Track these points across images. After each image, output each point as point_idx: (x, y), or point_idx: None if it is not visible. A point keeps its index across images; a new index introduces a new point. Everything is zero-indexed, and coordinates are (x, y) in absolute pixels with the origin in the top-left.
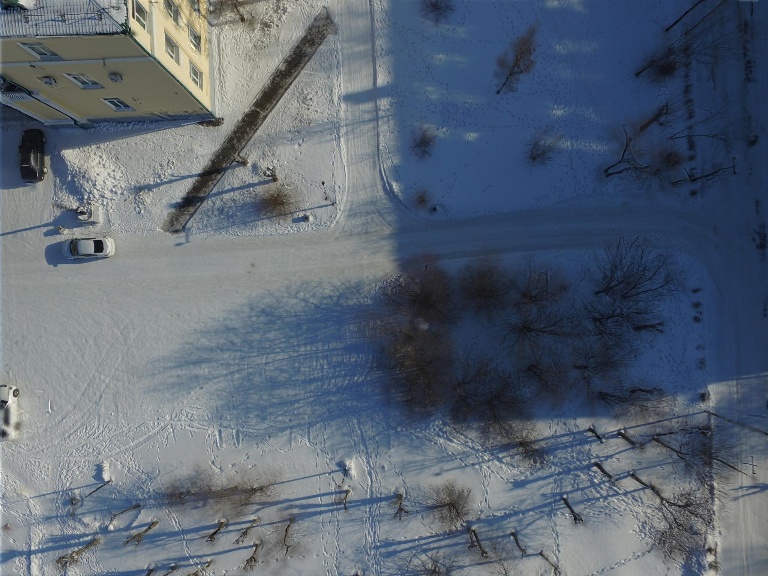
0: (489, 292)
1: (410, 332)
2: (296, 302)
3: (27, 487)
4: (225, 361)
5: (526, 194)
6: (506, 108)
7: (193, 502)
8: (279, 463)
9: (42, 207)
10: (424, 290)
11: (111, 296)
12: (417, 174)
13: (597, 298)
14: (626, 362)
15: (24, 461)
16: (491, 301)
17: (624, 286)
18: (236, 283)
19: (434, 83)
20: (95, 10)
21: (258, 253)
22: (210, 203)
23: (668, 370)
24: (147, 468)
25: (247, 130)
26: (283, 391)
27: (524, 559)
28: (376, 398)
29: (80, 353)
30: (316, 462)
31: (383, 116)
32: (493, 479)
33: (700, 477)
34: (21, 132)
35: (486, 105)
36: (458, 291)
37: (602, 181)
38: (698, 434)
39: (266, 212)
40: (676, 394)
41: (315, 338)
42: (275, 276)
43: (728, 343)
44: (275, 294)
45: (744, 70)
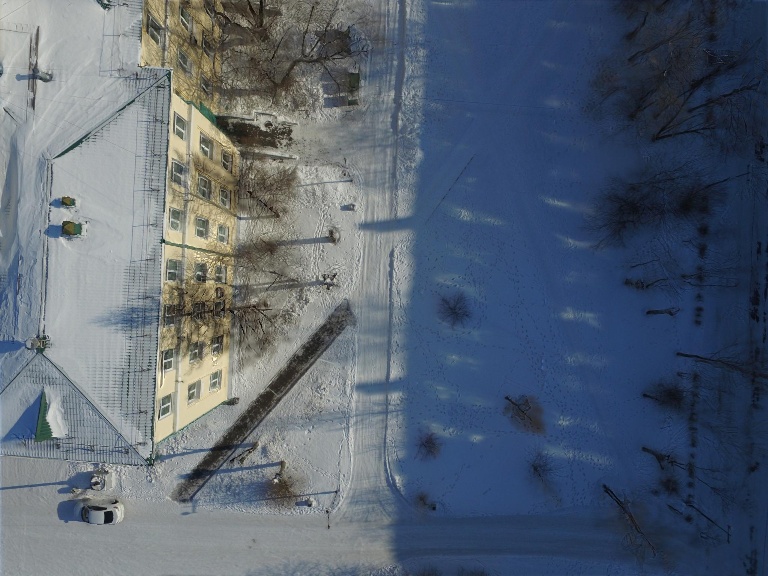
0: None
1: None
2: None
3: None
4: None
5: (525, 500)
6: None
7: None
8: None
9: (59, 465)
10: None
11: (116, 557)
12: (420, 471)
13: None
14: None
15: None
16: None
17: None
18: (236, 557)
19: (445, 383)
20: (123, 445)
21: (260, 530)
22: (219, 479)
23: None
24: None
25: (260, 410)
26: None
27: None
28: None
29: None
30: None
31: (393, 411)
32: None
33: None
34: None
35: (494, 409)
36: None
37: (600, 494)
38: None
39: (271, 493)
40: None
41: None
42: (274, 554)
43: None
44: (273, 571)
45: (751, 396)
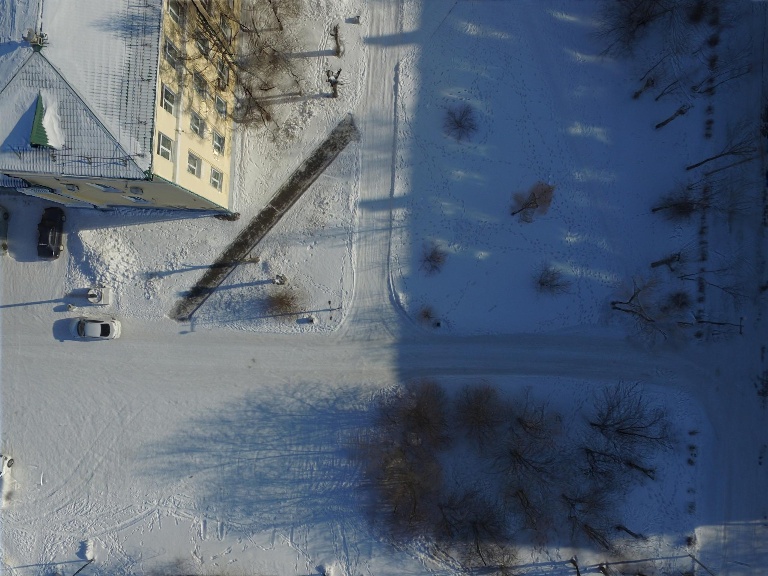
0: (484, 420)
1: (402, 445)
2: (292, 401)
3: (12, 557)
4: (217, 453)
5: (531, 318)
6: (519, 230)
7: None
8: (260, 561)
9: (55, 283)
10: (420, 405)
11: (112, 377)
12: (424, 288)
13: (592, 430)
14: (614, 502)
15: (11, 530)
16: (485, 428)
17: (619, 426)
18: (236, 376)
19: (450, 199)
20: (121, 156)
21: (260, 349)
22: (218, 296)
23: (656, 510)
24: (130, 551)
25: (262, 227)
26: (271, 488)
27: None
28: (362, 506)
29: (77, 430)
30: (296, 563)
31: (397, 227)
32: None
33: None
34: (42, 208)
35: (500, 225)
36: (453, 412)
37: (608, 312)
38: None
39: (272, 310)
40: (662, 535)
41: (308, 439)
42: (274, 373)
43: (720, 488)
44: (273, 391)
45: (762, 214)
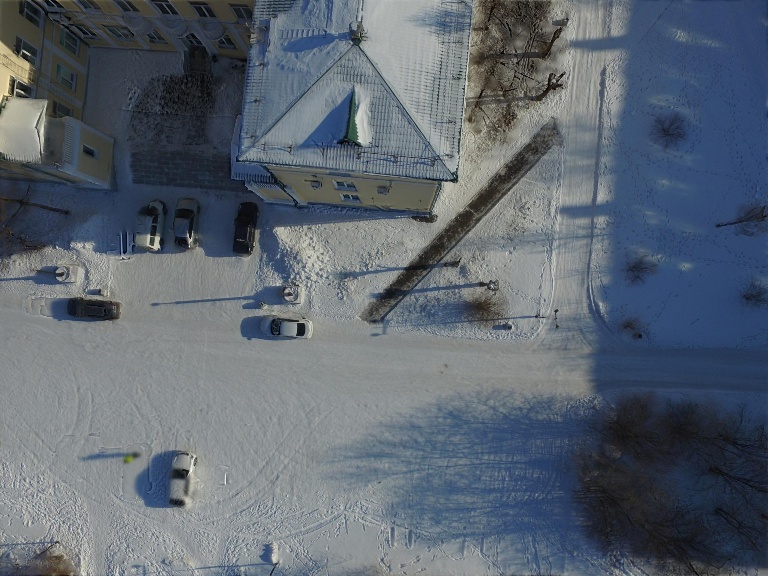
0: (697, 436)
1: (600, 458)
2: (485, 409)
3: (194, 557)
4: (406, 459)
5: (733, 333)
6: (723, 243)
7: None
8: (450, 571)
9: (245, 279)
10: (622, 418)
11: (301, 377)
12: (626, 298)
13: None
14: None
15: (193, 530)
16: (697, 444)
17: None
18: (427, 381)
19: (654, 208)
20: (429, 156)
21: (453, 354)
22: (413, 298)
23: None
24: (316, 556)
25: (459, 230)
26: (461, 497)
27: None
28: (555, 518)
29: (263, 430)
30: (487, 575)
31: (598, 235)
32: None
33: None
34: (234, 202)
35: (704, 237)
36: (659, 426)
37: None
38: None
39: (468, 315)
40: None
41: (500, 448)
42: (467, 380)
43: None
44: (465, 398)
45: None
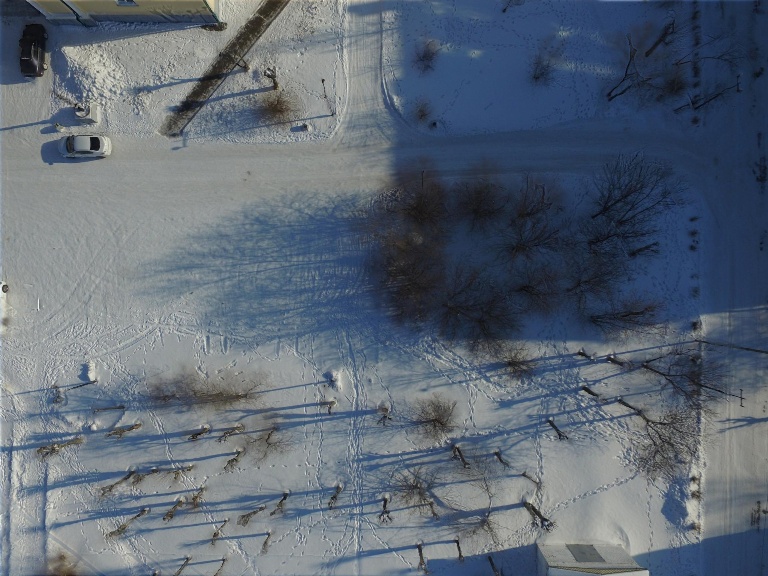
0: (485, 205)
1: (404, 246)
2: (291, 212)
3: (12, 383)
4: (216, 267)
5: (527, 114)
6: (512, 27)
7: (177, 406)
8: (266, 371)
9: (40, 104)
10: (420, 204)
11: (105, 197)
12: (419, 89)
13: (593, 221)
14: (619, 283)
15: (10, 357)
16: (486, 214)
17: (621, 206)
18: (231, 190)
19: None
20: None
21: (255, 161)
22: (209, 108)
23: (661, 297)
24: (133, 370)
25: (250, 37)
26: (273, 300)
27: (507, 479)
28: (366, 312)
29: (71, 252)
30: (303, 372)
31: (387, 29)
32: (479, 397)
33: (688, 405)
34: (23, 27)
35: (492, 23)
36: (454, 205)
37: (604, 105)
38: (688, 361)
39: (265, 120)
40: (668, 322)
41: (308, 249)
42: (271, 185)
43: (723, 274)
44: (270, 203)
45: (753, 1)
